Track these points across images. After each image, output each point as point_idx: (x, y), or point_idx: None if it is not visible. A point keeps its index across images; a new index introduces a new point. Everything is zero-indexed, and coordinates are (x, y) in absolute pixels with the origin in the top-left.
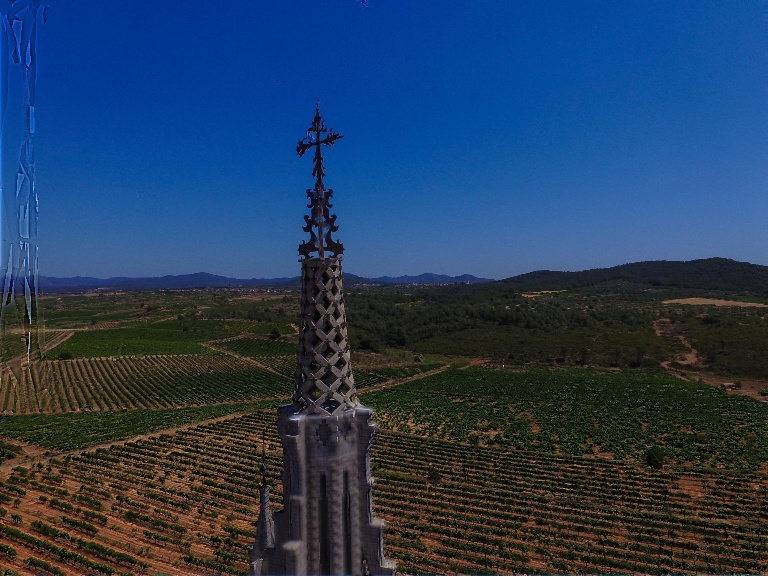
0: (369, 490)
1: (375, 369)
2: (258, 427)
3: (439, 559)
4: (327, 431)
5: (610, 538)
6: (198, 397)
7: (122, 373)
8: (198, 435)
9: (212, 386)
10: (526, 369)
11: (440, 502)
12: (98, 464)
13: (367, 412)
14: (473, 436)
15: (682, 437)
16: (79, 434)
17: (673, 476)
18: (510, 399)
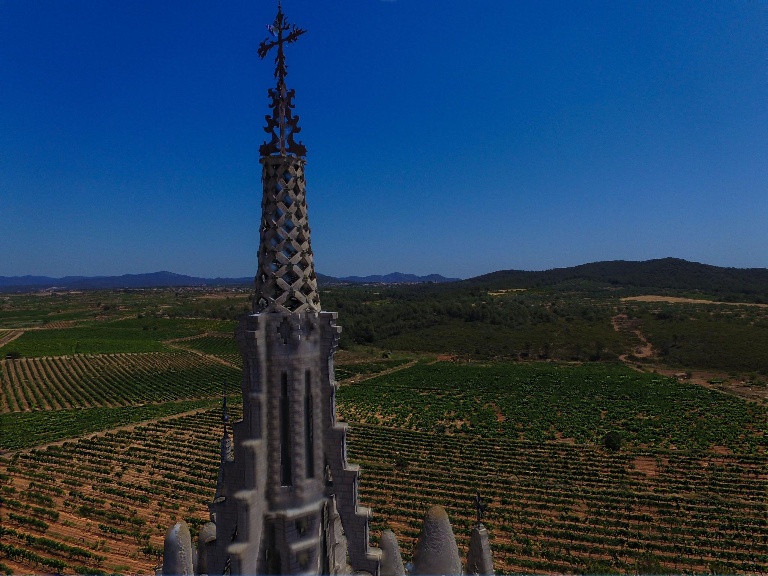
0: (332, 393)
1: (343, 365)
2: None
3: (406, 540)
4: (288, 330)
5: (571, 514)
6: (159, 395)
7: (76, 372)
8: (158, 430)
9: (174, 384)
10: (491, 363)
11: (407, 487)
12: (49, 461)
13: (330, 313)
14: (440, 425)
15: (638, 422)
16: (28, 433)
17: (630, 457)
18: (476, 391)
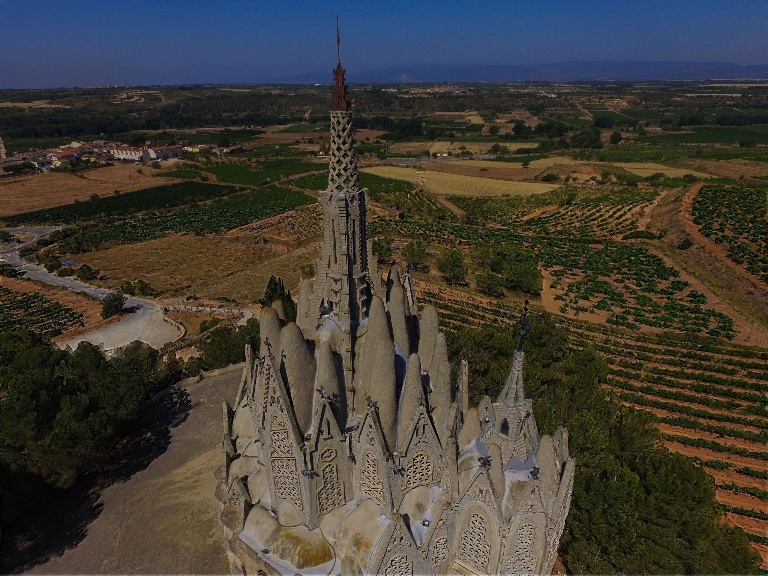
0: None
1: None
2: None
3: None
4: None
5: None
6: None
7: None
8: None
9: None
10: None
11: None
12: None
13: None
14: None
15: None
16: None
17: None
18: None
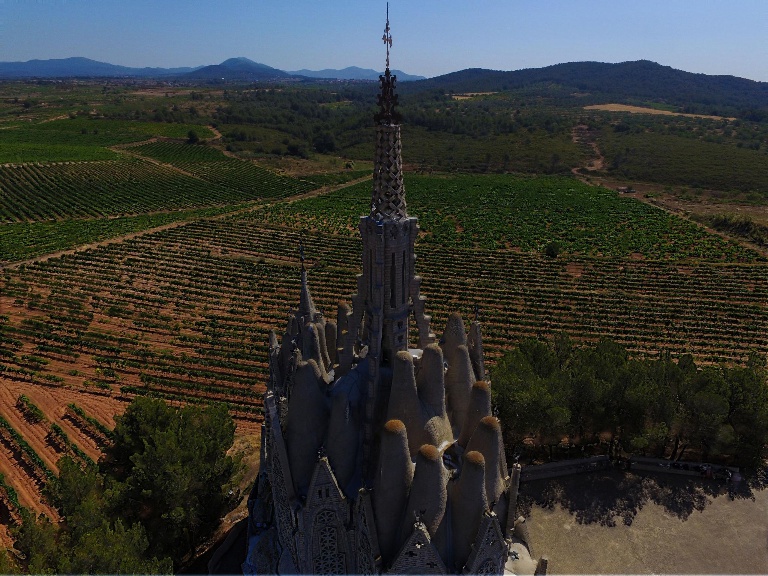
0: None
1: (307, 176)
2: (205, 234)
3: None
4: (396, 231)
5: None
6: (128, 206)
7: (31, 182)
8: (148, 243)
9: (139, 195)
10: (452, 175)
11: None
12: (57, 271)
13: (416, 220)
14: None
15: (576, 233)
16: (17, 245)
17: (564, 263)
18: (438, 204)
